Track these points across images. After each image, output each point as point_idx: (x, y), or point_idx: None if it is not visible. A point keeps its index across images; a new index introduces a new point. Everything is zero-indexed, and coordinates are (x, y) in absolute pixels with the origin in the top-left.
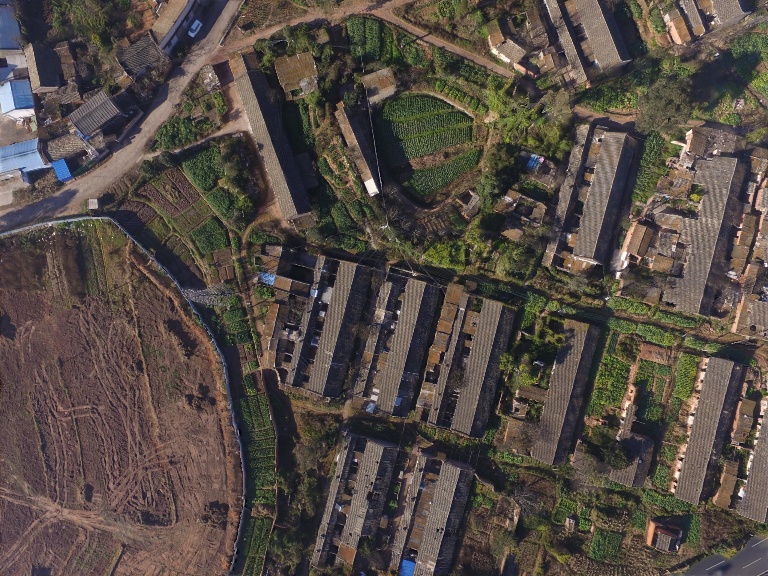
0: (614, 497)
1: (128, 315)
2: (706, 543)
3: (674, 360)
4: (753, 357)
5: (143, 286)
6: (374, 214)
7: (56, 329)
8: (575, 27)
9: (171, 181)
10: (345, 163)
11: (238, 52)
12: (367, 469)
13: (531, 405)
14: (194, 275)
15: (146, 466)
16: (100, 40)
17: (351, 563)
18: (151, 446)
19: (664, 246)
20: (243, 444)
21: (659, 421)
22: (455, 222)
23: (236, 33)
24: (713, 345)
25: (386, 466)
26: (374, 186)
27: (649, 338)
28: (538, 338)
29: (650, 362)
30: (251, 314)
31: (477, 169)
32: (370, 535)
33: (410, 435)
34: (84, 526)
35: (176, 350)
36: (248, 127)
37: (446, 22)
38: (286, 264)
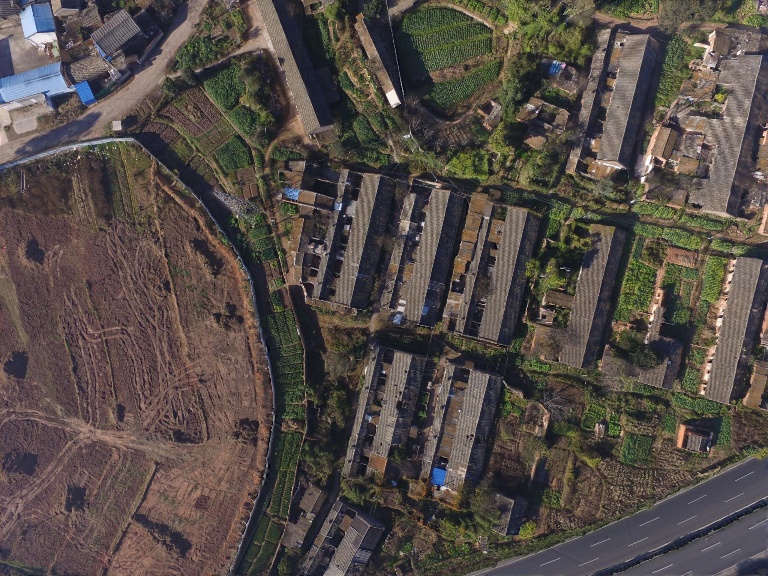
0: (643, 402)
1: (154, 236)
2: (737, 445)
3: (701, 263)
4: None
5: (168, 207)
6: (396, 126)
7: (84, 252)
8: None
9: (193, 101)
10: (366, 76)
11: None
12: (396, 379)
13: (558, 311)
14: None
15: (176, 385)
16: None
17: (382, 471)
18: (180, 365)
19: (689, 148)
20: (271, 360)
21: (687, 324)
22: (477, 133)
23: None
24: (740, 247)
25: (414, 376)
26: (396, 97)
27: (675, 241)
28: (564, 243)
29: (677, 266)
30: (276, 231)
31: (498, 81)
32: (400, 444)
33: (437, 346)
34: (117, 446)
35: (203, 269)
36: (268, 45)
37: None
38: (310, 179)
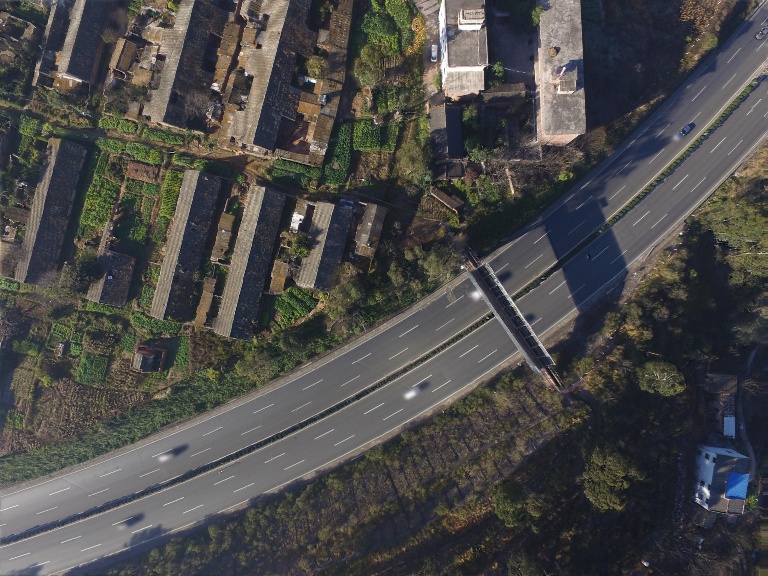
0: None
1: None
2: (193, 366)
3: (161, 178)
4: (242, 173)
5: None
6: None
7: None
8: None
9: None
10: None
11: None
12: None
13: (20, 228)
14: None
15: None
16: None
17: None
18: None
19: (145, 59)
20: None
21: (142, 240)
22: None
23: None
24: (198, 161)
25: None
26: None
27: (136, 156)
28: (21, 158)
29: (138, 181)
30: None
31: None
32: None
33: None
34: None
35: None
36: None
37: None
38: None
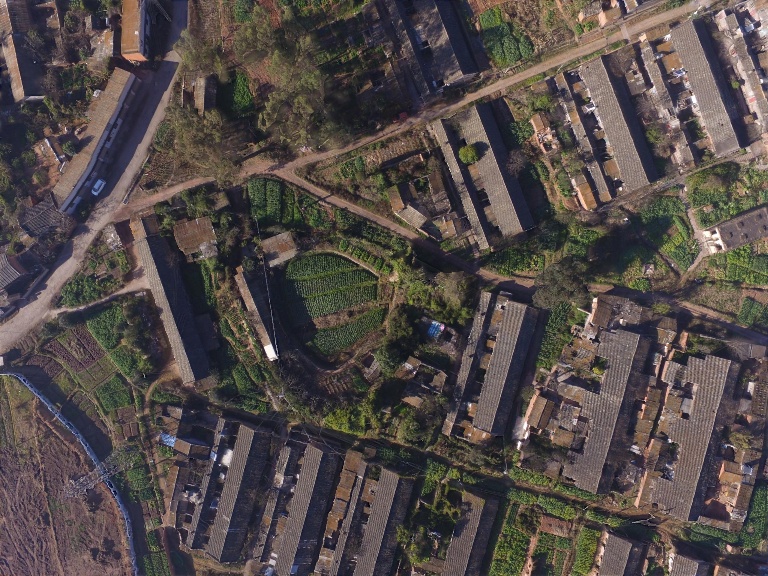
0: None
1: (35, 468)
2: None
3: (575, 533)
4: (656, 532)
5: (49, 441)
6: (274, 378)
7: None
8: (478, 192)
9: (76, 337)
10: (245, 326)
11: (139, 213)
12: None
13: (428, 575)
14: (99, 430)
15: None
16: (4, 200)
17: None
18: None
19: (565, 419)
20: None
21: None
22: (357, 384)
23: (139, 191)
24: (615, 520)
25: None
26: (273, 352)
27: (549, 511)
28: (435, 510)
29: (550, 535)
30: (154, 472)
31: (382, 328)
32: None
33: None
34: None
35: (82, 504)
36: None
37: (349, 183)
38: (187, 426)
